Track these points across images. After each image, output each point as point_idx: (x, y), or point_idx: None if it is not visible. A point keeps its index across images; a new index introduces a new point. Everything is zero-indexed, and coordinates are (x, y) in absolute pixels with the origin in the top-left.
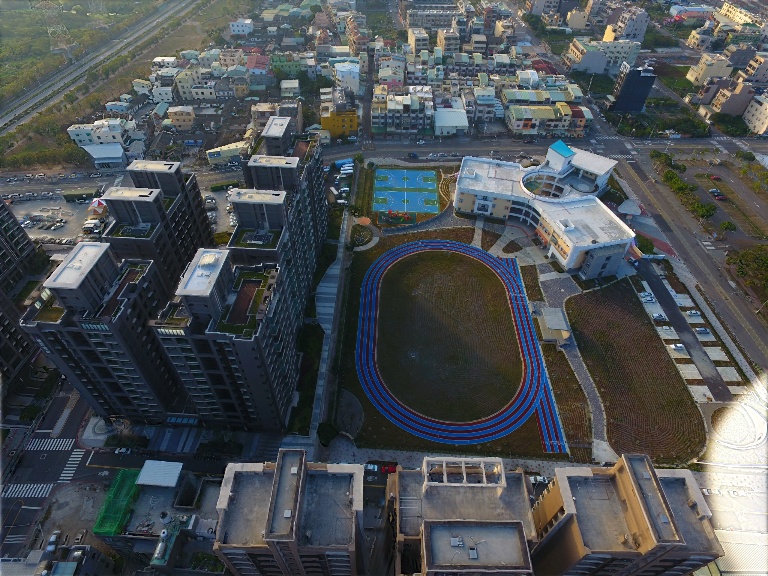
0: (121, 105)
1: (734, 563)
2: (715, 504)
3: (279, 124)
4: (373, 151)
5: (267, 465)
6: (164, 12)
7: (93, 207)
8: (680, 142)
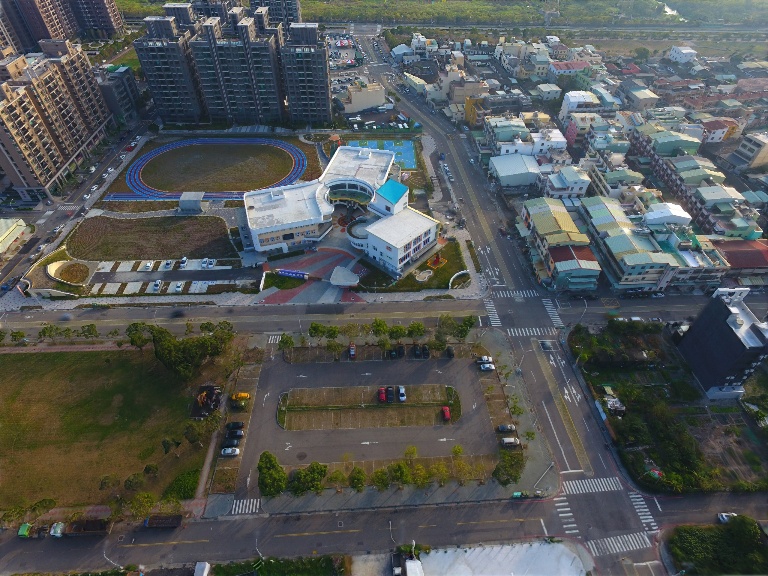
0: (466, 43)
1: (0, 224)
2: (37, 247)
3: None
4: (446, 139)
5: (78, 51)
6: (698, 29)
7: (342, 60)
8: (583, 414)
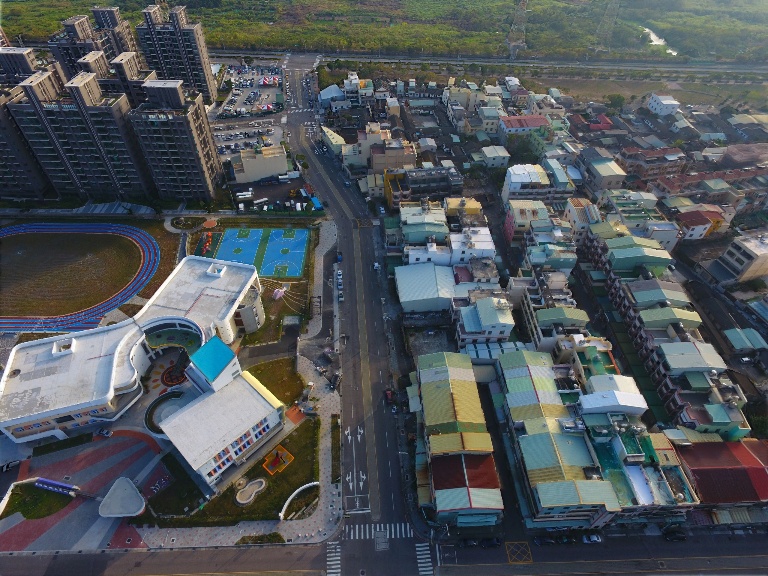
0: (410, 84)
1: None
2: None
3: (164, 84)
4: (352, 226)
5: None
6: (686, 66)
7: None
8: None
